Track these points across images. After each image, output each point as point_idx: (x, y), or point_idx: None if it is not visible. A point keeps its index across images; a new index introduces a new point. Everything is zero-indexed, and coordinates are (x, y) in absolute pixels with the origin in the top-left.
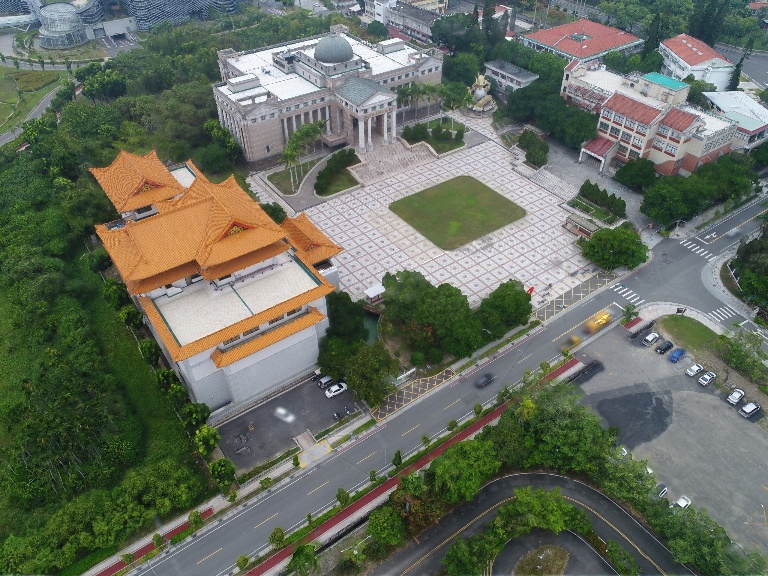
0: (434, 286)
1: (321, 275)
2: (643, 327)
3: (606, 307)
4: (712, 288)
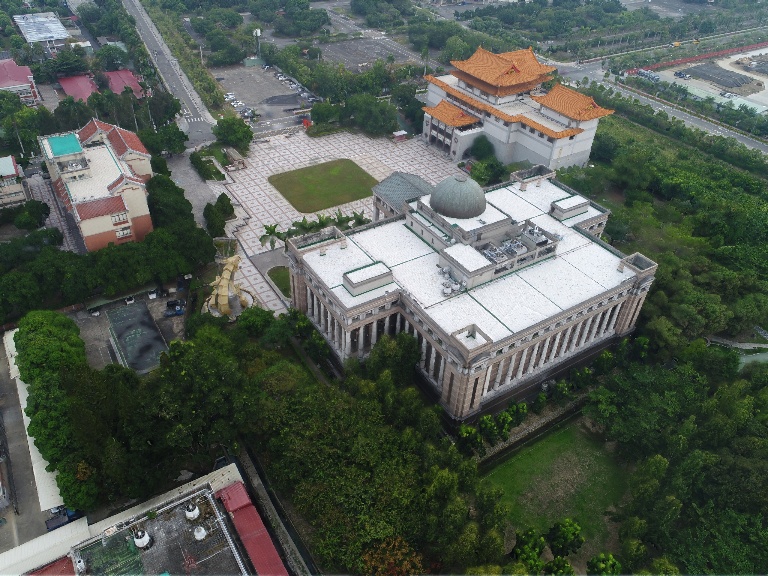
0: (367, 110)
1: (432, 82)
2: (248, 119)
3: (260, 127)
4: (185, 128)
